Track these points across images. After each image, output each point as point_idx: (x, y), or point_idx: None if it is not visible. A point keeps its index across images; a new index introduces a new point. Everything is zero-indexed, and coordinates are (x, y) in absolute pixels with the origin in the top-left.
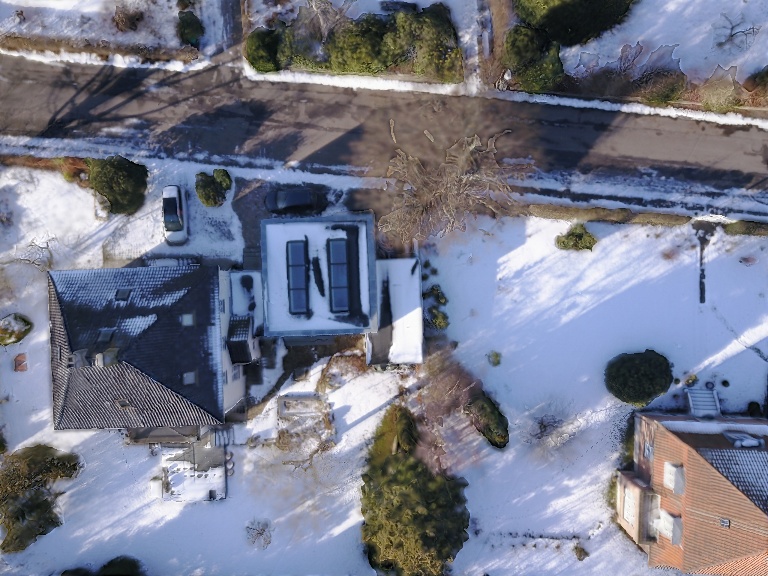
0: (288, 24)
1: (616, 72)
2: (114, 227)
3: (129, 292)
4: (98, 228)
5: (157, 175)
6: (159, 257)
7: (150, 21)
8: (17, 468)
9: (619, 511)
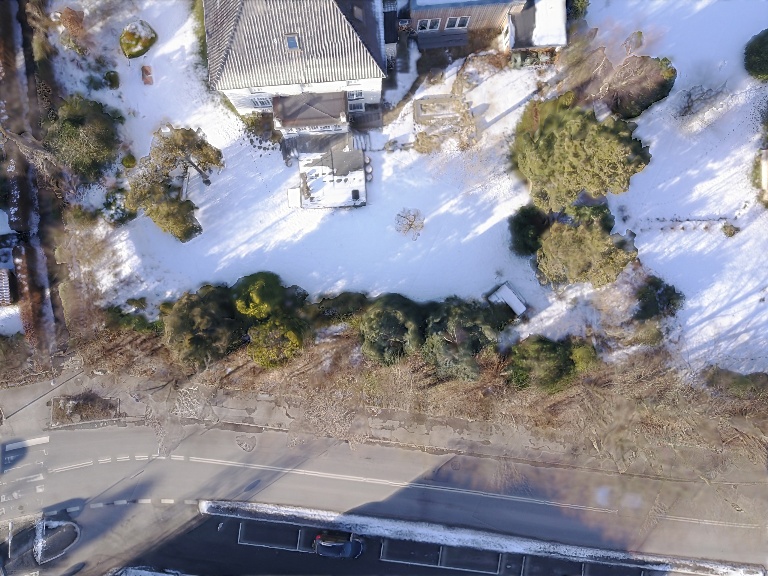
0: None
1: None
2: None
3: None
4: None
5: None
6: None
7: None
8: (168, 143)
9: (766, 185)
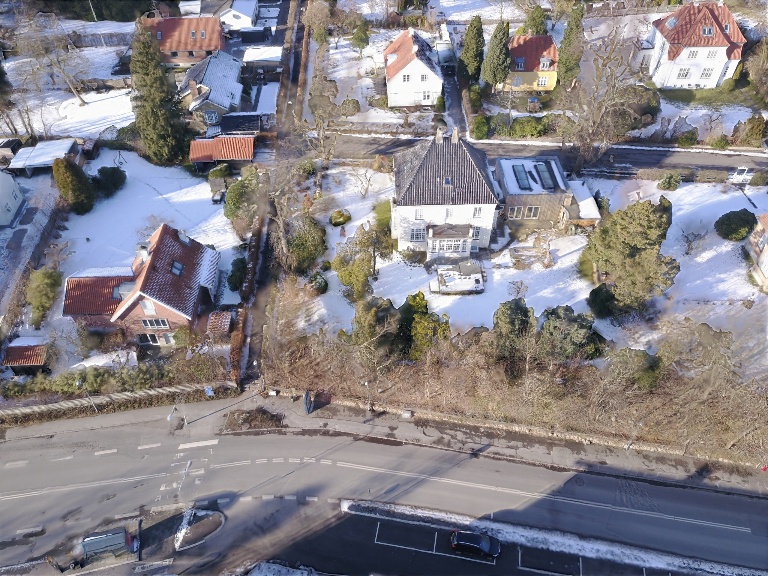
0: None
1: (661, 131)
2: None
3: None
4: None
5: None
6: None
7: None
8: (366, 231)
9: (761, 282)
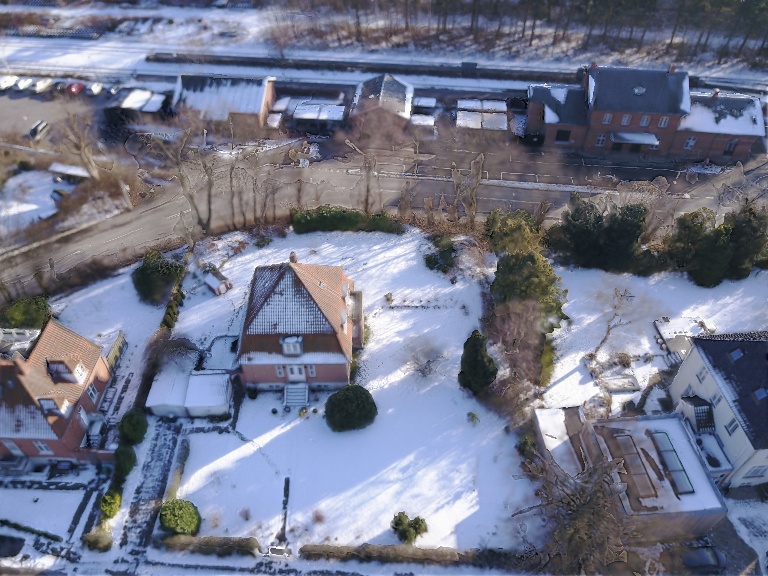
0: None
1: None
2: None
3: None
4: None
5: None
6: None
7: None
8: None
9: None
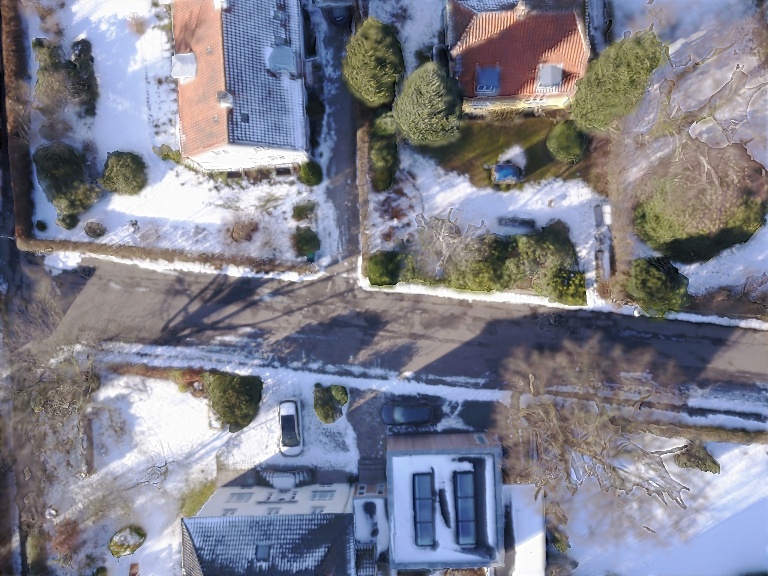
0: (404, 237)
1: (739, 296)
2: (228, 437)
3: (269, 550)
4: (211, 438)
5: (271, 385)
6: (273, 468)
7: (265, 232)
8: None
9: None
